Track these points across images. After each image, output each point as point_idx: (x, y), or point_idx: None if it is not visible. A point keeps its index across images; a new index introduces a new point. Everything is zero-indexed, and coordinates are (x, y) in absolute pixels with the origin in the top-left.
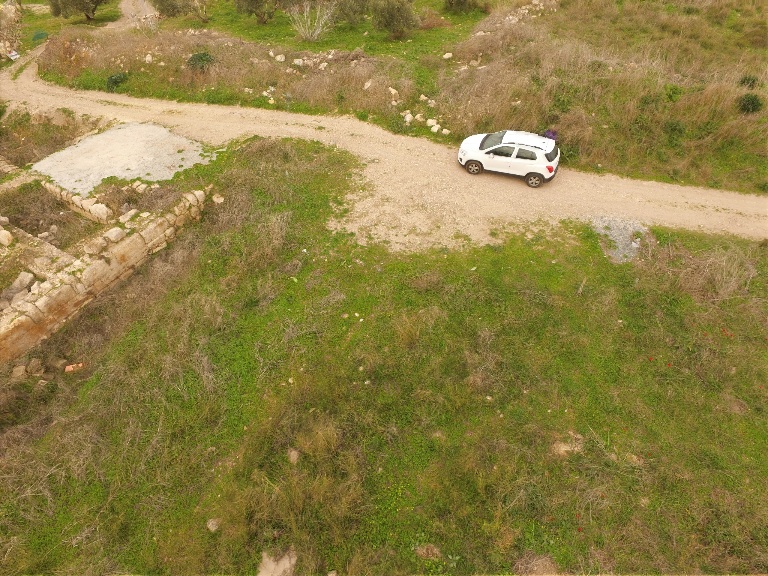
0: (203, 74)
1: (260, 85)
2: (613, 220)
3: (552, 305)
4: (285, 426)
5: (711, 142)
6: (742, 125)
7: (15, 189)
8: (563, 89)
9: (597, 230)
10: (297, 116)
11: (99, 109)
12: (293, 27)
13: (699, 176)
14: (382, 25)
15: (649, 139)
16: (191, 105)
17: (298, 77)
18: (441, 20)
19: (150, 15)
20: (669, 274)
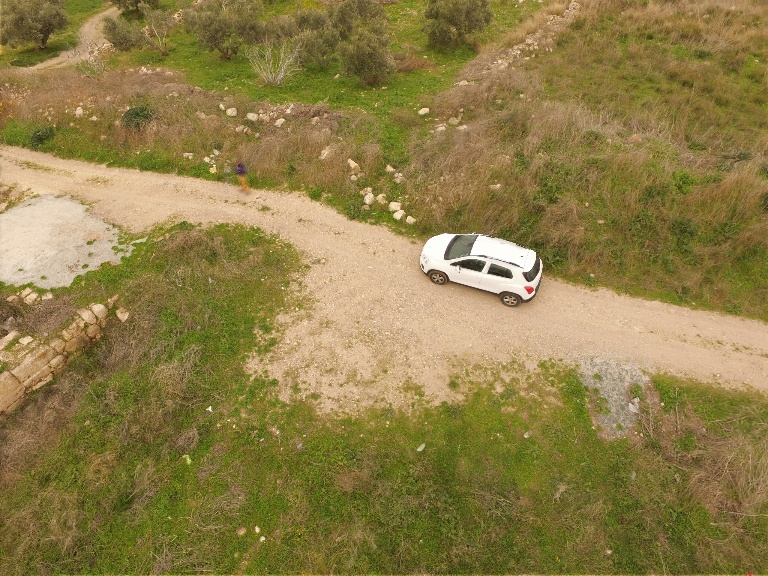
0: (138, 133)
1: (203, 148)
2: (606, 363)
3: (519, 519)
4: None
5: (729, 251)
6: (767, 230)
7: None
8: (552, 169)
9: (585, 380)
10: (240, 190)
11: (15, 174)
12: (254, 70)
13: (714, 297)
14: (351, 72)
15: (653, 242)
16: (121, 171)
17: (249, 136)
18: (423, 61)
19: (105, 46)
20: (676, 478)
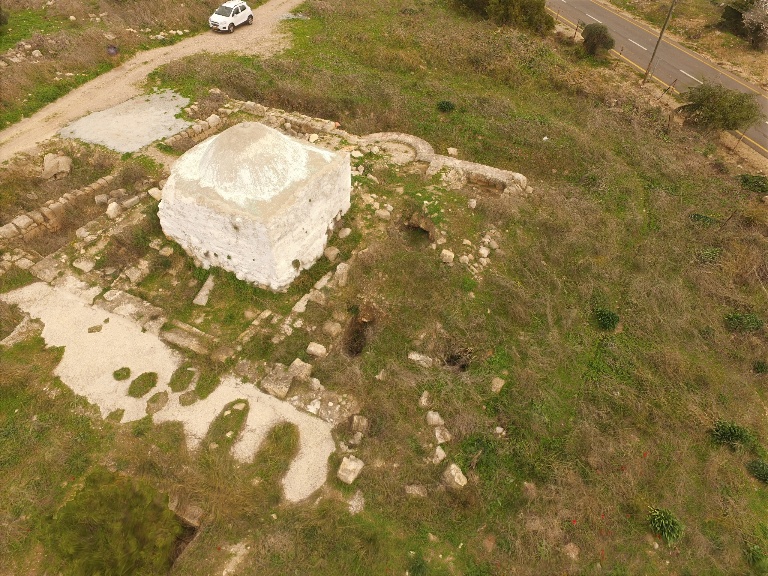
0: None
1: None
2: (283, 16)
3: None
4: (381, 60)
5: None
6: None
7: (178, 140)
8: None
9: None
10: (116, 70)
11: None
12: None
13: None
14: None
15: None
16: (44, 110)
17: None
18: None
19: None
20: None
